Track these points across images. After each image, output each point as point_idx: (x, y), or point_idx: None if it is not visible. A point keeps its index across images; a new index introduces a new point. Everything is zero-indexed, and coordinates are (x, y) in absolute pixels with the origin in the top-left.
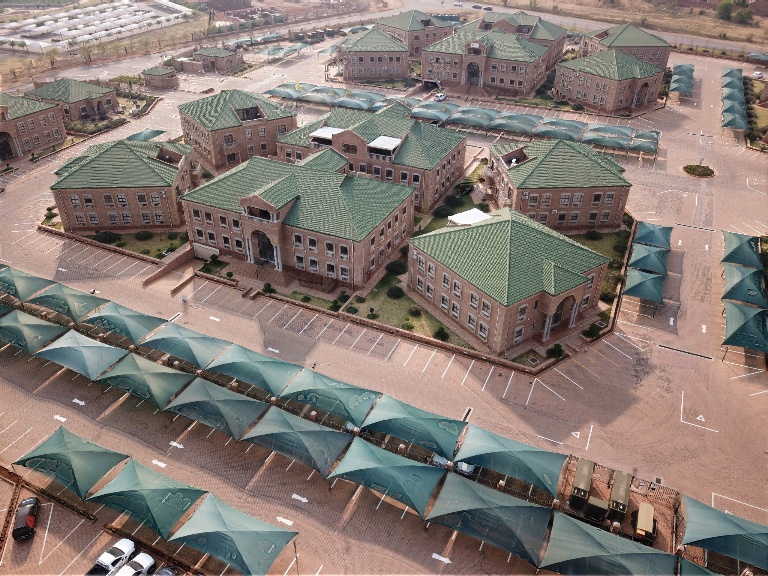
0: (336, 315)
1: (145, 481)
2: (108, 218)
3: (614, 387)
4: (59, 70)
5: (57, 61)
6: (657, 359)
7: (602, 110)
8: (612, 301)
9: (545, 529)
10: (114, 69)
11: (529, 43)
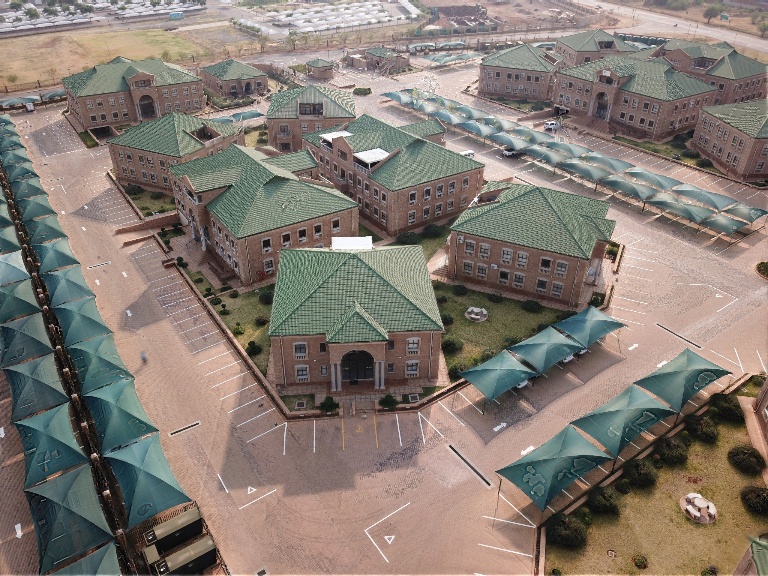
0: None
1: None
2: (142, 175)
3: (345, 464)
4: (265, 54)
5: (267, 46)
6: (427, 458)
7: (733, 172)
8: (458, 380)
9: (86, 550)
10: (303, 58)
11: (686, 79)
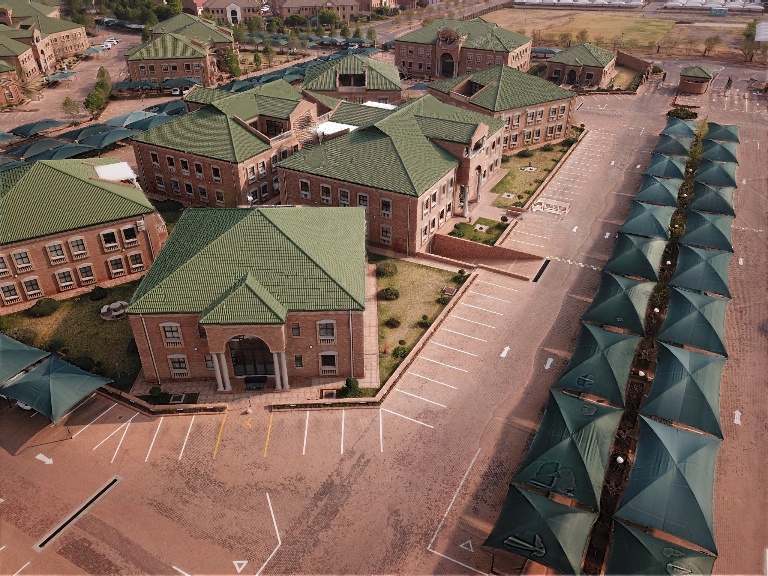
0: None
1: None
2: None
3: None
4: None
5: (715, 50)
6: None
7: None
8: None
9: None
10: (733, 71)
11: None
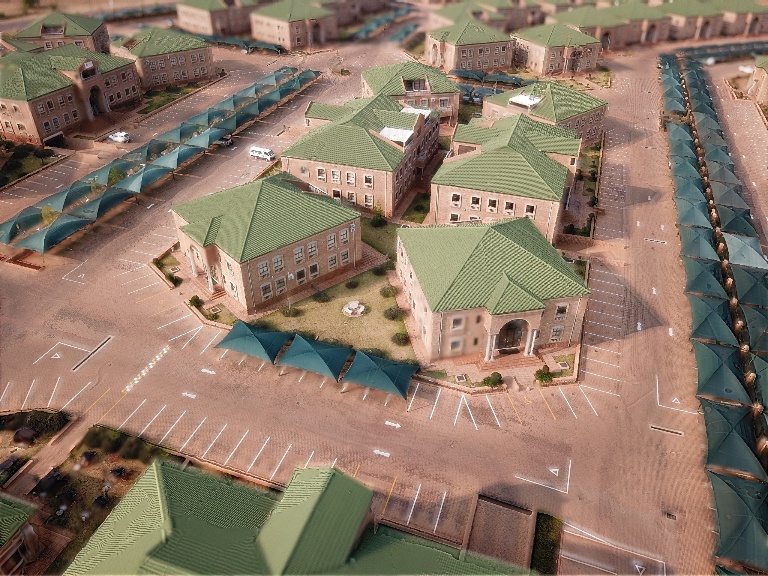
0: (599, 179)
1: None
2: None
3: None
4: None
5: None
6: None
7: (207, 79)
8: None
9: None
10: None
11: None
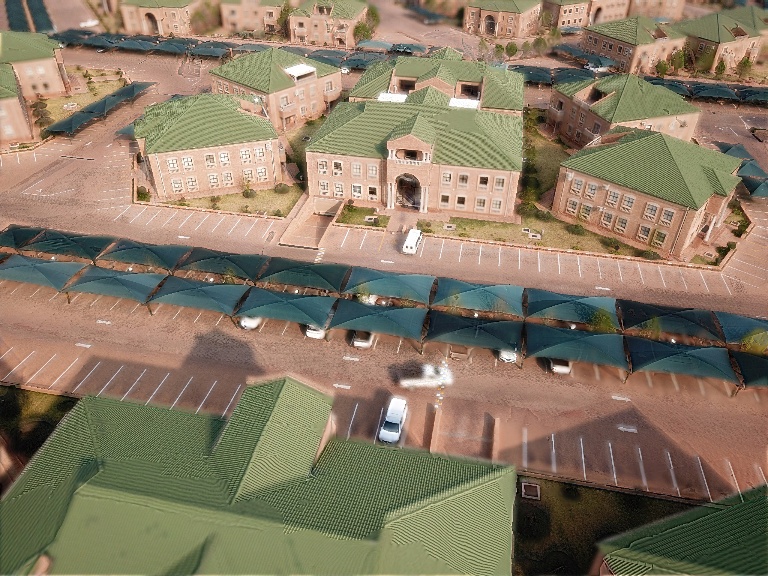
0: None
1: (411, 46)
2: None
3: None
4: None
5: None
6: None
7: None
8: None
9: None
10: None
11: (4, 561)
